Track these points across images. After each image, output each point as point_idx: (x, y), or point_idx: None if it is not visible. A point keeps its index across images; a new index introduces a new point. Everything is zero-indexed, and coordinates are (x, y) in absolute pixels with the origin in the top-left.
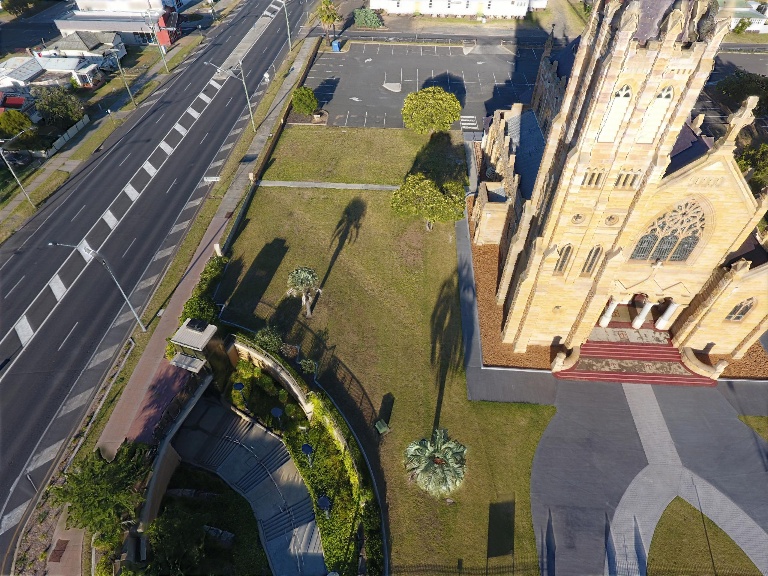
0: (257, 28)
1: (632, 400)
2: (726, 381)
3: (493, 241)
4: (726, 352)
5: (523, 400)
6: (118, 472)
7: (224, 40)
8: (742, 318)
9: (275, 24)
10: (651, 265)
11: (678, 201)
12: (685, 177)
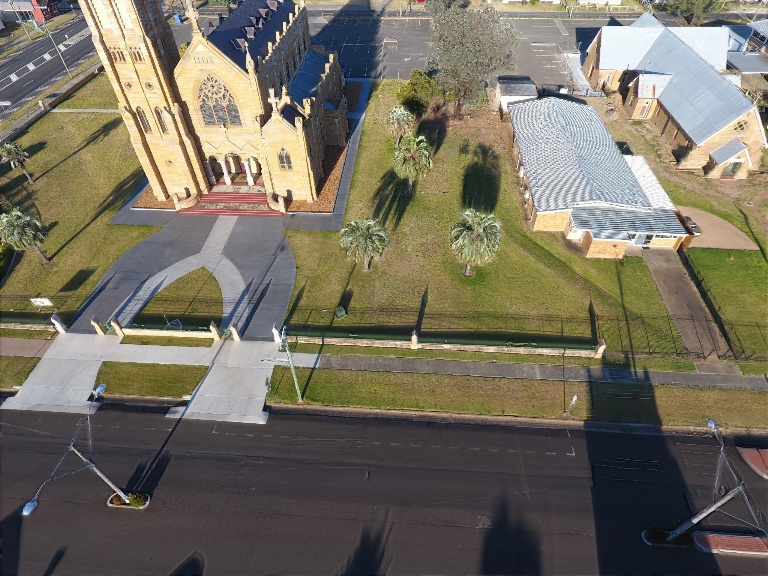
0: None
1: (218, 223)
2: (292, 214)
3: None
4: (304, 198)
5: (144, 224)
6: None
7: None
8: (292, 167)
9: None
10: (219, 128)
11: (199, 76)
12: (188, 57)
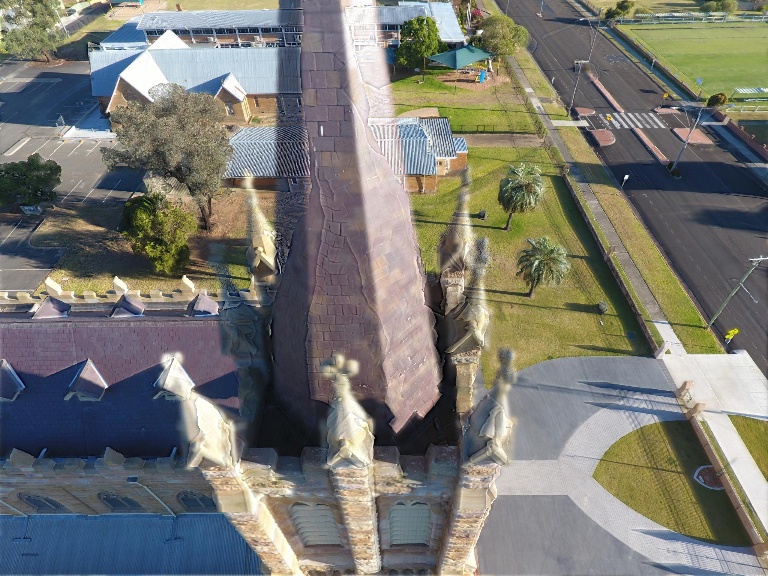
0: None
1: None
2: None
3: None
4: None
5: None
6: None
7: None
8: None
9: None
10: None
11: None
12: None
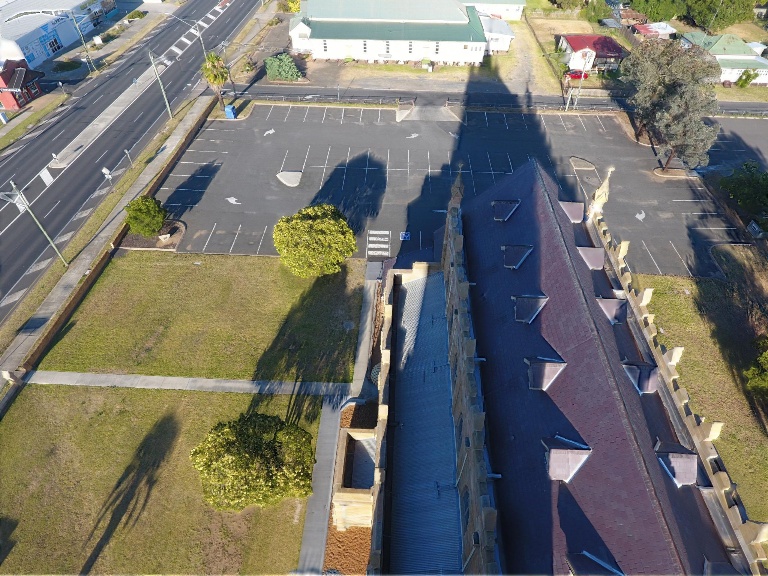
0: (141, 82)
1: None
2: None
3: (364, 524)
4: None
5: None
6: None
7: (92, 101)
8: None
9: (167, 76)
10: None
11: None
12: None
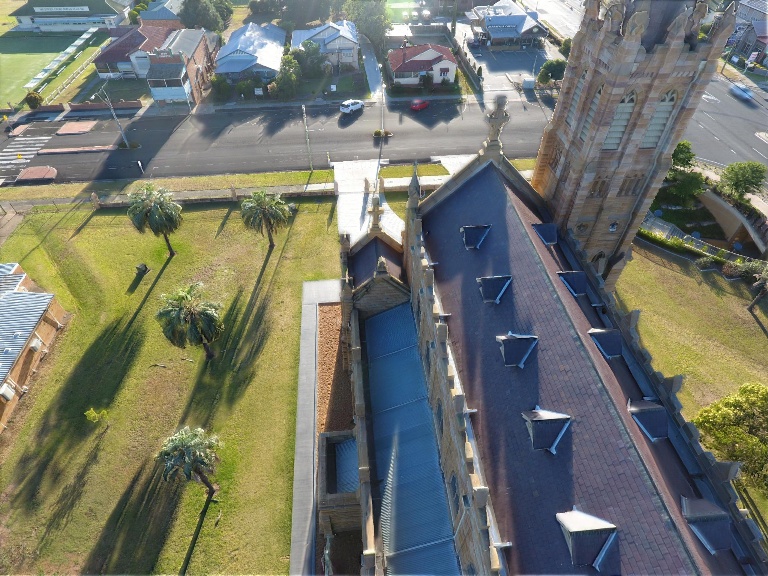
0: None
1: None
2: None
3: None
4: None
5: None
6: (743, 176)
7: None
8: None
9: None
10: None
11: None
12: None
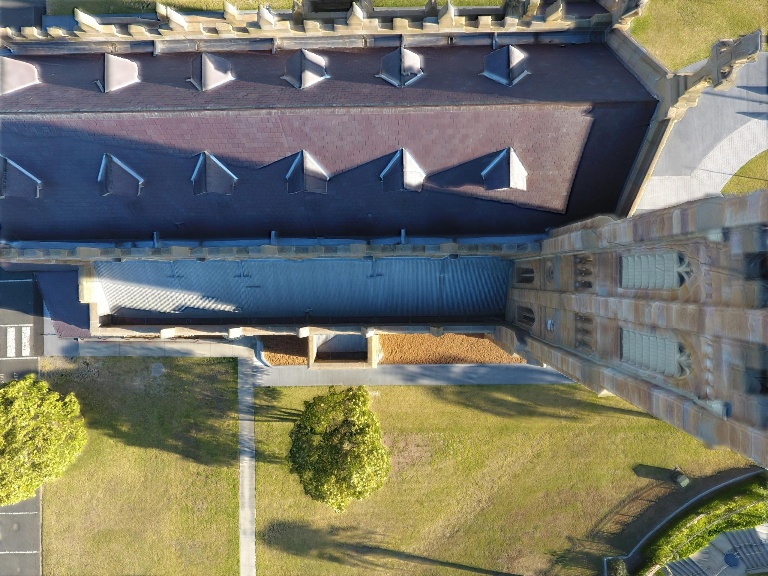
0: None
1: None
2: None
3: None
4: None
5: None
6: None
7: None
8: None
9: None
10: None
11: None
12: None
